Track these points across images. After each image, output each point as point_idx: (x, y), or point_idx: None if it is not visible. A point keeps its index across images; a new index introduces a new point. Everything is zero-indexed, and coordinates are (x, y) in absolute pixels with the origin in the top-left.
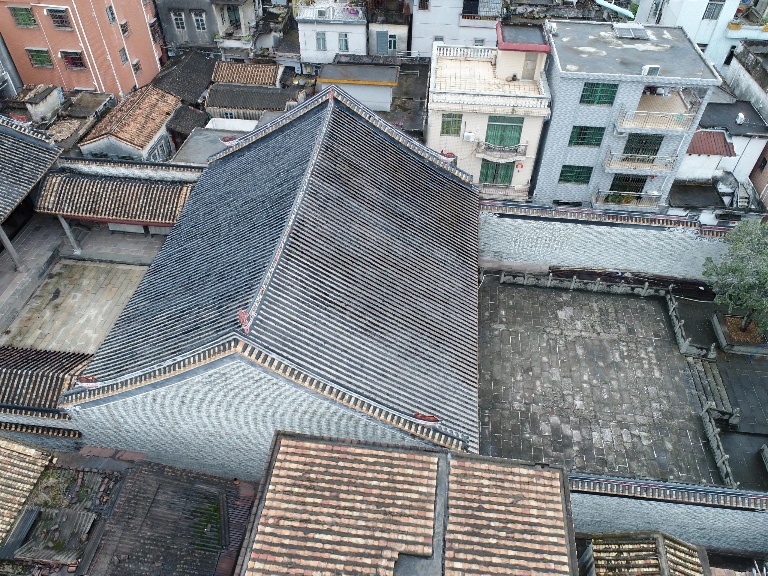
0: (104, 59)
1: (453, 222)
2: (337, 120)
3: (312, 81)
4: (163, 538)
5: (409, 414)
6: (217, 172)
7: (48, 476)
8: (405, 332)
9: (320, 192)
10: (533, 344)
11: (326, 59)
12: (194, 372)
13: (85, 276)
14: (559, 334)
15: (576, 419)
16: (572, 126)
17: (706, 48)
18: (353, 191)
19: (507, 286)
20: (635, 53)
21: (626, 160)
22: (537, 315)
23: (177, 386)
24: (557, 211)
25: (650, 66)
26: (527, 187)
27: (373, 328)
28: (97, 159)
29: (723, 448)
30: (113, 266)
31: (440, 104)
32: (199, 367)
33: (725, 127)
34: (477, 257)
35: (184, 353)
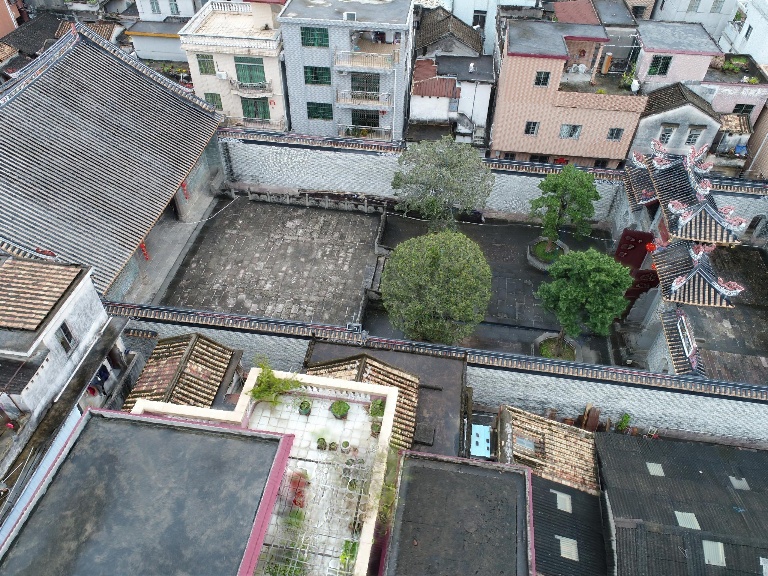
0: None
1: (177, 138)
2: (79, 51)
3: None
4: None
5: (32, 249)
6: None
7: None
8: (75, 204)
9: (33, 100)
10: (253, 244)
11: None
12: None
13: None
14: (279, 238)
15: (260, 297)
16: (303, 66)
17: (486, 15)
18: (71, 103)
19: (255, 203)
20: (356, 5)
21: (356, 98)
22: (268, 224)
23: None
24: (289, 138)
25: (347, 12)
26: (279, 121)
27: (40, 196)
28: None
29: (360, 315)
30: None
31: (189, 45)
32: None
33: (456, 74)
34: (191, 165)
35: None
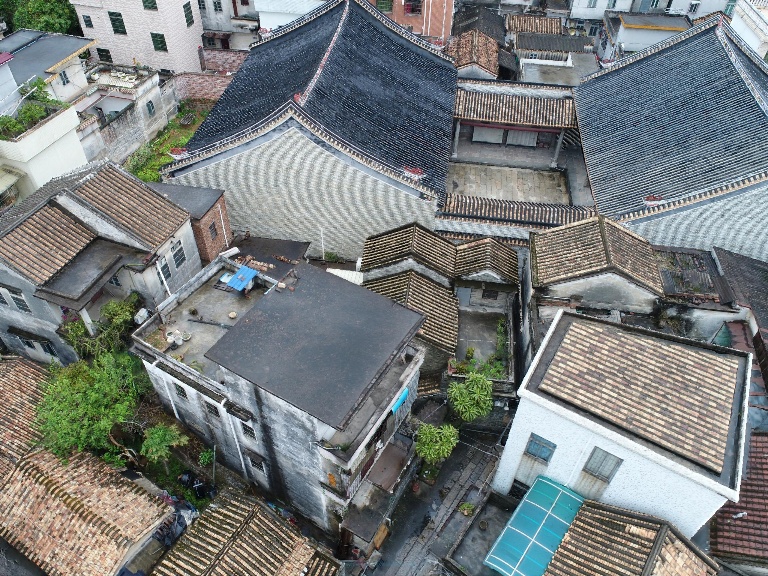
0: (440, 7)
1: None
2: None
3: (586, 33)
4: (761, 288)
5: None
6: (594, 88)
7: (655, 255)
8: None
9: None
10: None
11: (593, 15)
12: (758, 185)
13: (469, 173)
14: None
15: None
16: None
17: None
18: None
19: None
20: None
21: None
22: None
23: (732, 199)
24: None
25: None
26: None
27: None
28: (484, 79)
29: None
30: (486, 167)
31: None
32: (766, 180)
33: None
34: None
35: (759, 170)
